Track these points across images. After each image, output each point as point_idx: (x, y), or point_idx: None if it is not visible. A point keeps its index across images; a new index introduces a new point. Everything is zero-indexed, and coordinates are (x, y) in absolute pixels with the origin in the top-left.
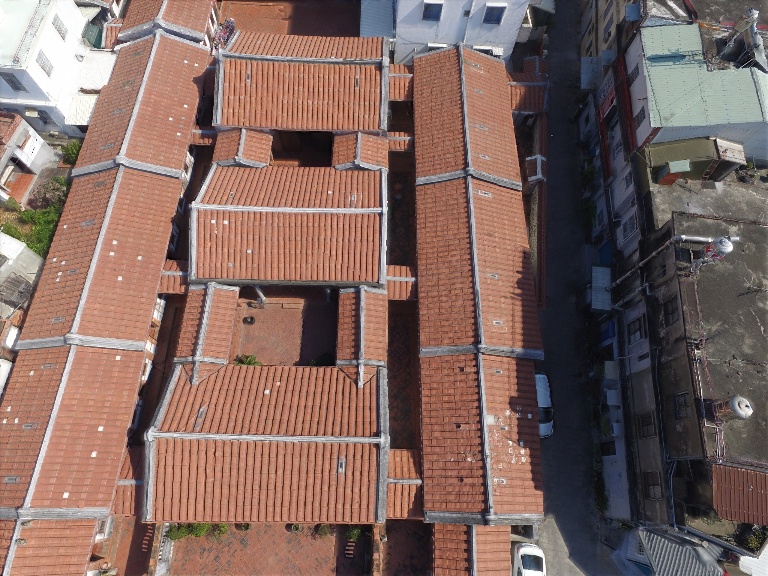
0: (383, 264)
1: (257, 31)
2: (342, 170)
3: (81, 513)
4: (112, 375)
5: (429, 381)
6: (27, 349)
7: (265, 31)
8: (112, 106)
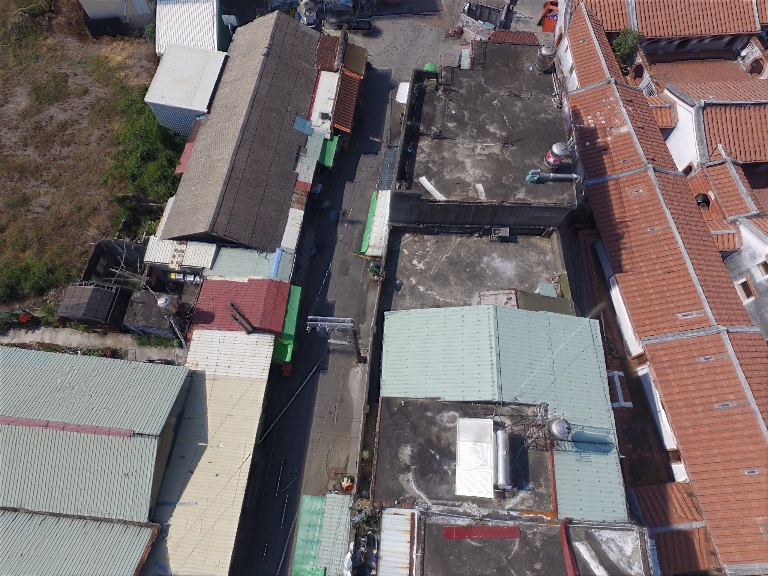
0: (753, 228)
1: None
2: None
3: None
4: None
5: (669, 157)
6: None
7: None
8: None
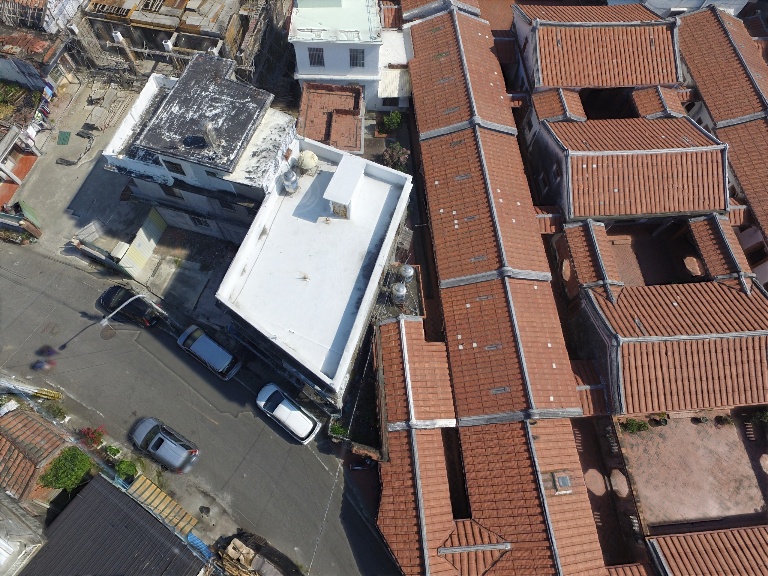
0: None
1: (490, 8)
2: (653, 119)
3: (566, 413)
4: (538, 302)
5: None
6: (451, 287)
7: (497, 8)
8: (434, 76)
